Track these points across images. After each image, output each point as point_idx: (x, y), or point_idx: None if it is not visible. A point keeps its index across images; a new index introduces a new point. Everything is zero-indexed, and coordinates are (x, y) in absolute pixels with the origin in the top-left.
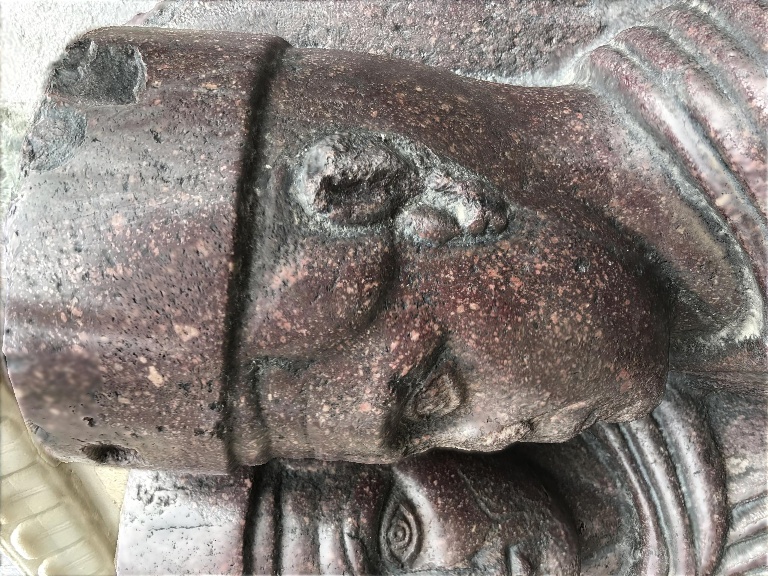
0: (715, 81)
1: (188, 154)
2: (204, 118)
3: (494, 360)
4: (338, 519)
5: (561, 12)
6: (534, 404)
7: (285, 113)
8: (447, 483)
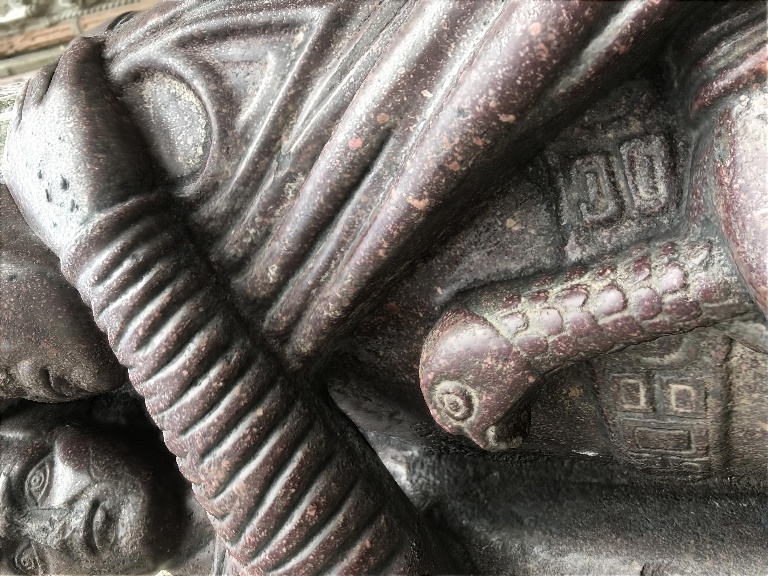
0: None
1: None
2: None
3: None
4: (4, 464)
5: None
6: None
7: None
8: (76, 453)
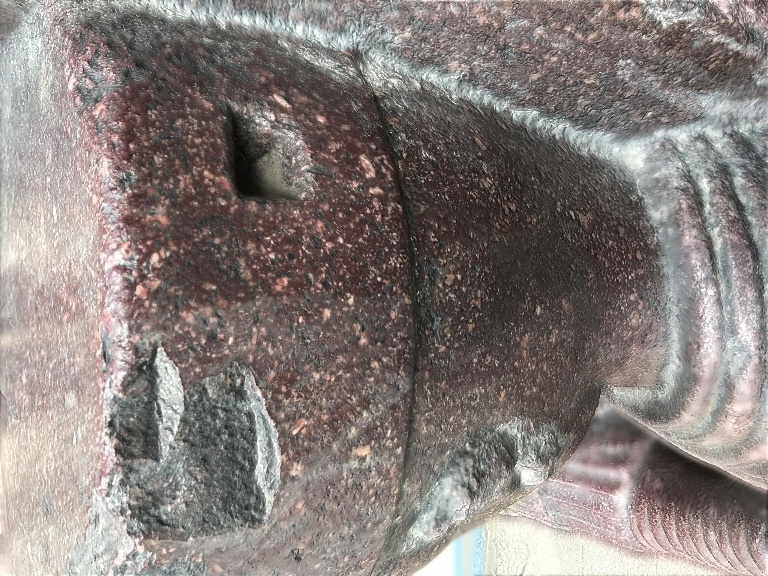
0: (764, 378)
1: (331, 561)
2: (354, 509)
3: None
4: None
5: (681, 93)
6: None
7: (427, 439)
8: None
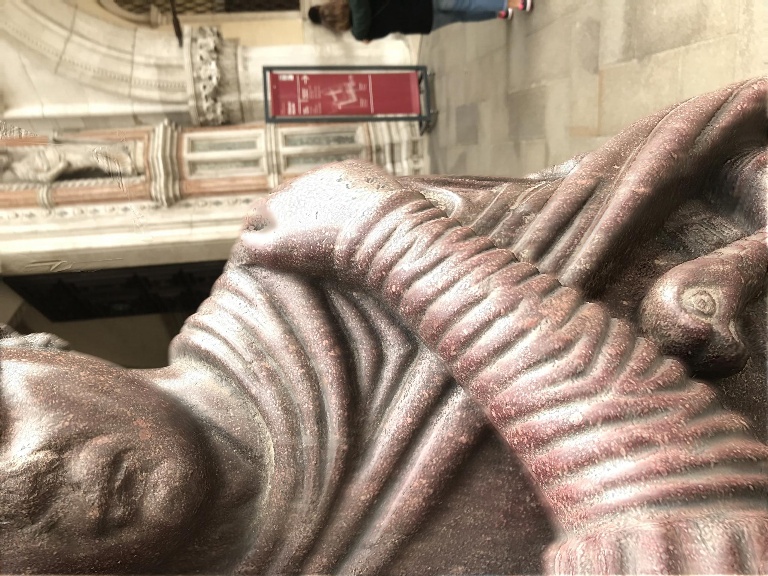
0: None
1: None
2: None
3: (30, 385)
4: None
5: None
6: (59, 424)
7: None
8: None
